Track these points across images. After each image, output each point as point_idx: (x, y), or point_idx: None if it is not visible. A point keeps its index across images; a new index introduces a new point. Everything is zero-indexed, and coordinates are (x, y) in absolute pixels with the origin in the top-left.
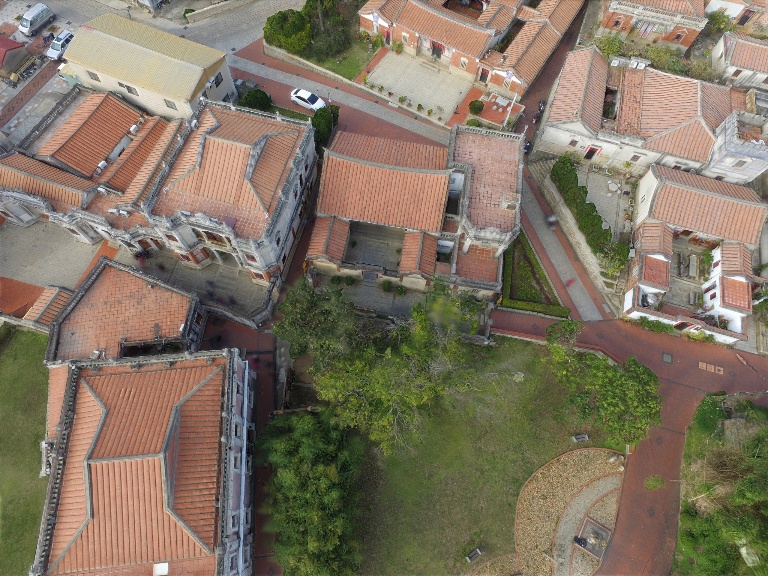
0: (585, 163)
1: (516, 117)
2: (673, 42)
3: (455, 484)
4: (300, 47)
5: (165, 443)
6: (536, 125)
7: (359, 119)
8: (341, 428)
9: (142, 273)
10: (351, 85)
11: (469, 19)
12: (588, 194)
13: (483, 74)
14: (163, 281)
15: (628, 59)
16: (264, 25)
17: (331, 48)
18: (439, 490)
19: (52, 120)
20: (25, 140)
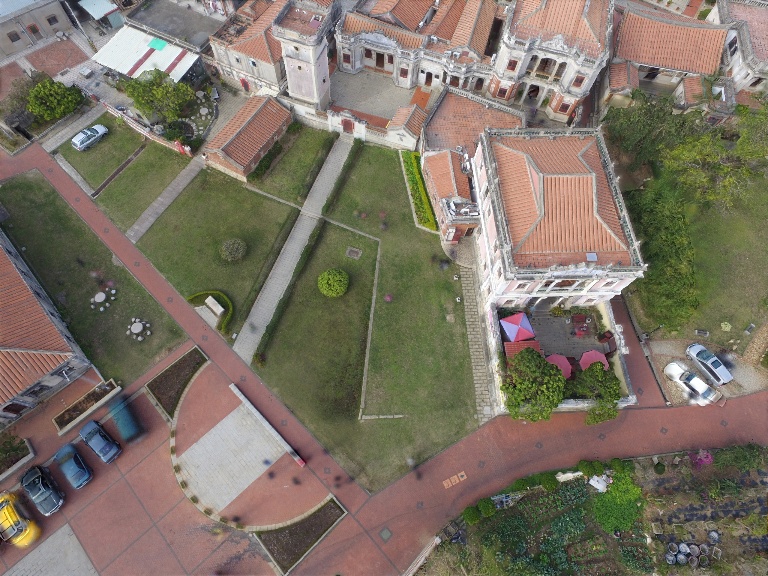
0: None
1: None
2: None
3: (747, 259)
4: None
5: (591, 169)
6: None
7: None
8: (698, 182)
9: (481, 96)
10: None
11: None
12: None
13: None
14: (500, 102)
15: None
16: None
17: None
18: (735, 262)
19: None
20: (359, 3)
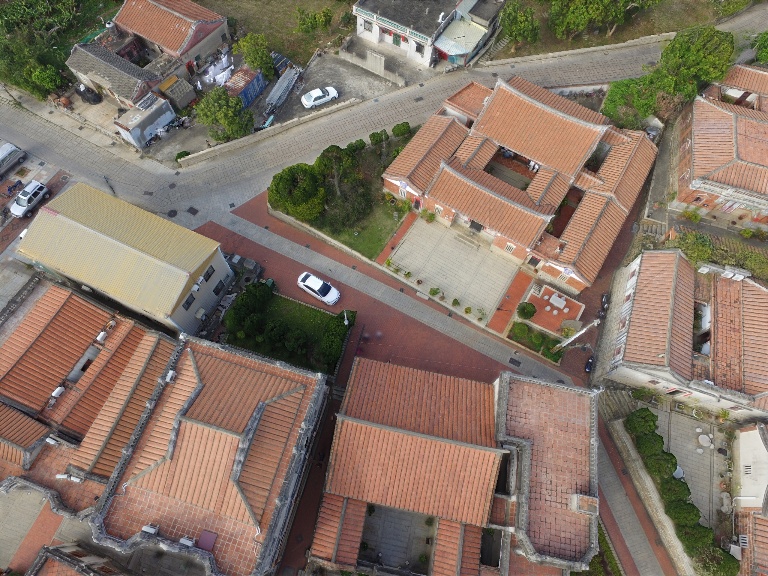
0: (666, 399)
1: (581, 345)
2: (766, 224)
3: None
4: (311, 216)
5: None
6: (598, 328)
7: (380, 315)
8: None
9: None
10: (371, 265)
11: (517, 191)
12: (672, 448)
13: (533, 259)
14: None
15: (721, 268)
16: (269, 174)
17: (348, 217)
18: None
19: (2, 323)
20: None
